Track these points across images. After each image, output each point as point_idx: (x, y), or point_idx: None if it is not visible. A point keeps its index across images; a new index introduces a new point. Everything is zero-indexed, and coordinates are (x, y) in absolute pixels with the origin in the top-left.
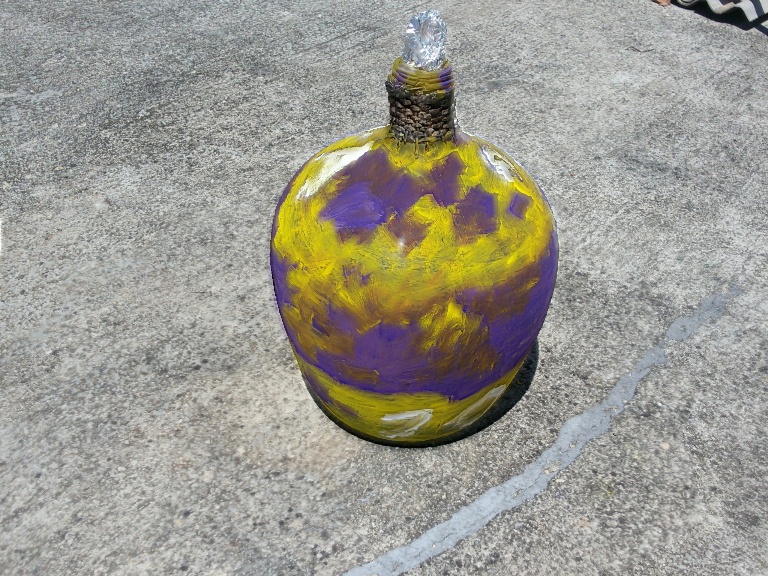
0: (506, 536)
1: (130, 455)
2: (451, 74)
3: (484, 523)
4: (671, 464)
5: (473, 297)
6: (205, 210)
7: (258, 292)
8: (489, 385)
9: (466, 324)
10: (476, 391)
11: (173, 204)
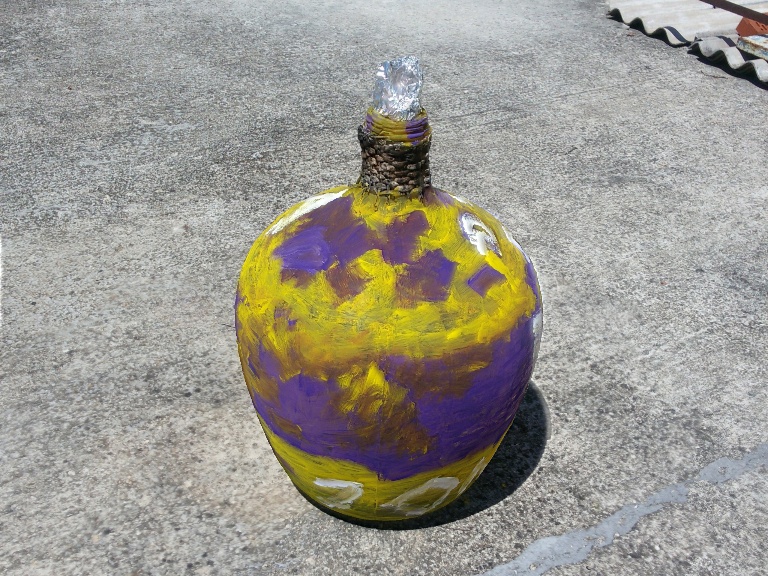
0: None
1: (86, 462)
2: (418, 127)
3: None
4: None
5: (399, 366)
6: None
7: None
8: (427, 472)
9: (388, 394)
10: (411, 475)
11: (243, 240)
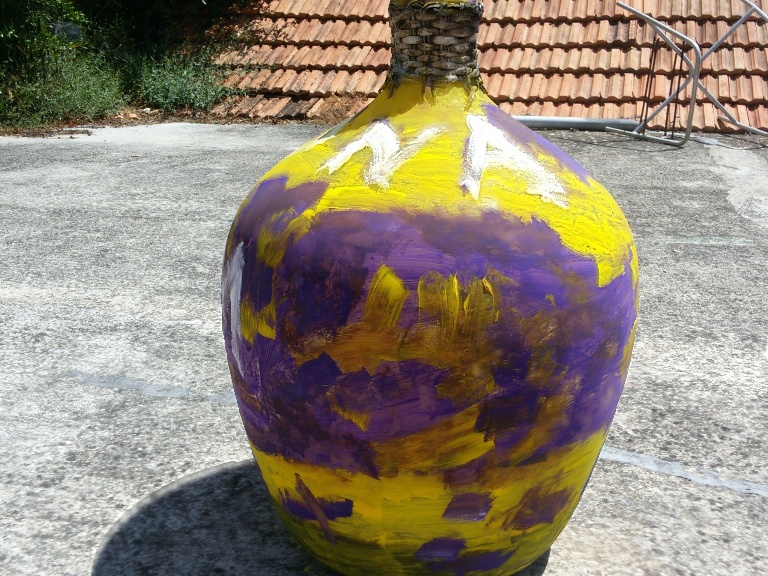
0: None
1: None
2: None
3: None
4: None
5: None
6: None
7: None
8: None
9: None
10: None
11: None
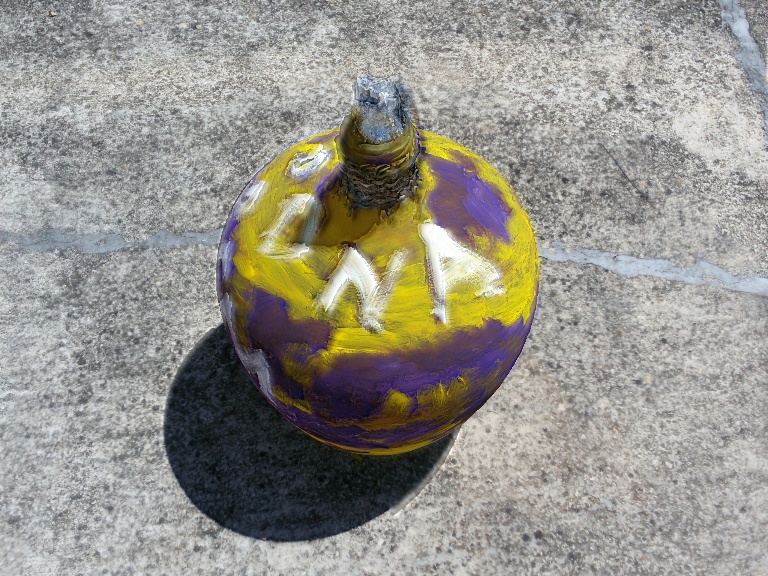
0: None
1: (655, 474)
2: None
3: None
4: None
5: None
6: None
7: None
8: None
9: None
10: None
11: None
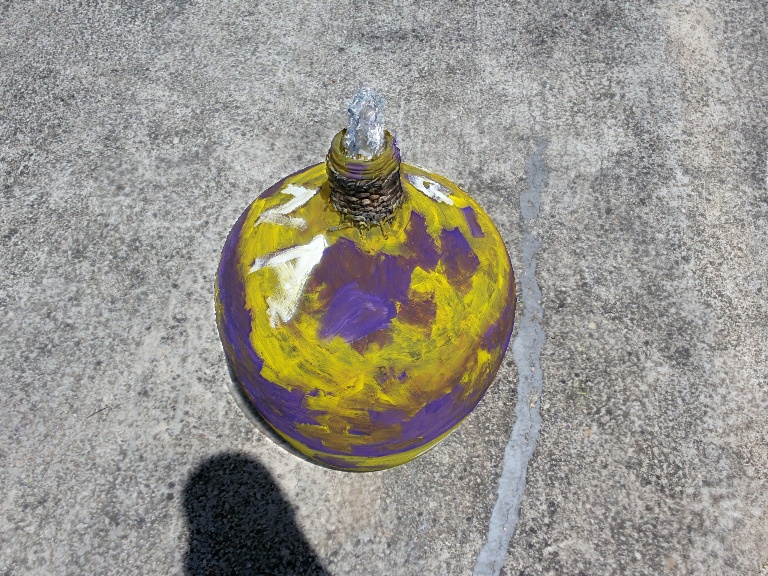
0: (546, 483)
1: None
2: (398, 150)
3: (524, 483)
4: (607, 340)
5: (491, 337)
6: (11, 311)
7: (154, 377)
8: None
9: (490, 361)
10: None
11: None
